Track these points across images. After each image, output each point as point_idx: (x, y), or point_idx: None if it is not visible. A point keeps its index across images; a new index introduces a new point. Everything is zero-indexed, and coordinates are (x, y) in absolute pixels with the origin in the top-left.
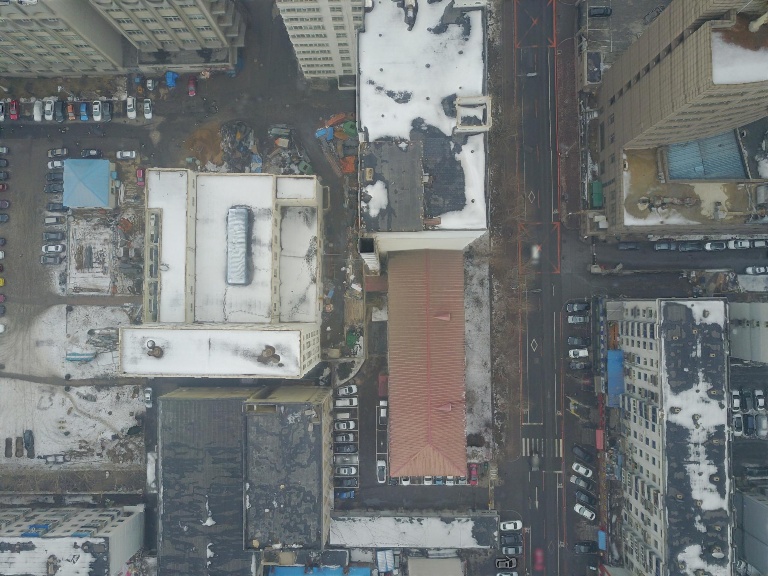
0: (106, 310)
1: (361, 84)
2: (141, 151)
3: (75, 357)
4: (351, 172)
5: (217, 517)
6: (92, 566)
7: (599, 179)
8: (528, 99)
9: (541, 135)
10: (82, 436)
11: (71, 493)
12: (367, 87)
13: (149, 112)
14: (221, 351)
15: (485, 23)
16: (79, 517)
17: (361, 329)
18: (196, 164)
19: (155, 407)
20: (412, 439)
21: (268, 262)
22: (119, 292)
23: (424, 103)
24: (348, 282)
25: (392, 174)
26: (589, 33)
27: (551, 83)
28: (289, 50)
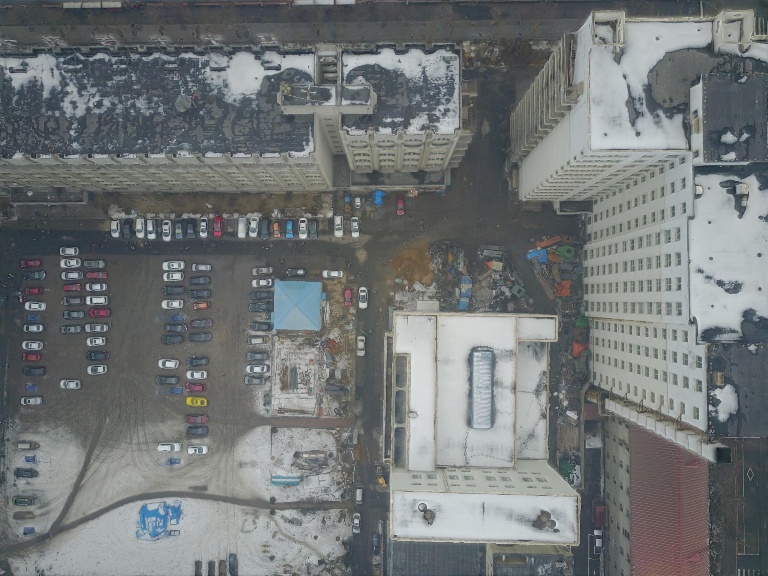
0: (312, 432)
1: (690, 273)
2: (347, 270)
3: (281, 480)
4: (565, 296)
5: None
6: None
7: None
8: None
9: None
10: (287, 560)
11: None
12: (696, 276)
13: (357, 231)
14: (495, 516)
15: None
16: None
17: (575, 457)
18: (404, 284)
19: (362, 532)
20: None
21: (510, 405)
22: (325, 414)
23: (756, 294)
24: (561, 408)
25: (742, 378)
26: None
27: None
28: (499, 169)
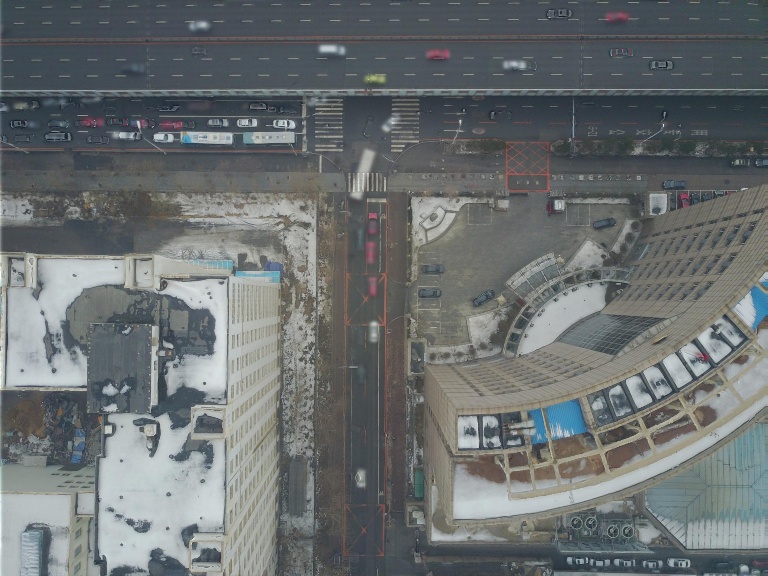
0: None
1: (100, 512)
2: None
3: None
4: None
5: None
6: None
7: (423, 465)
8: (357, 377)
9: (369, 414)
10: None
11: None
12: (106, 515)
13: None
14: None
15: (226, 455)
16: None
17: None
18: (18, 436)
19: None
20: None
21: None
22: None
23: (164, 533)
24: None
25: None
26: (419, 313)
27: (380, 362)
28: None
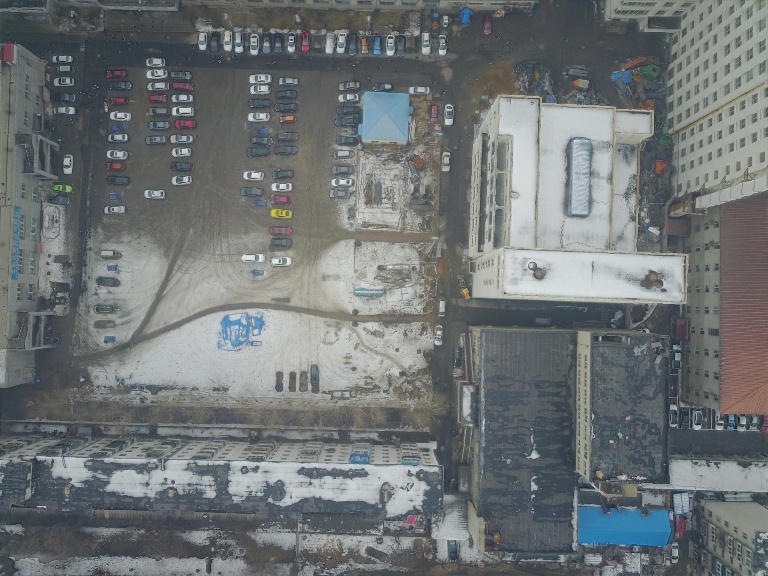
0: (395, 246)
1: None
2: (433, 88)
3: (364, 292)
4: None
5: (541, 450)
6: (426, 494)
7: None
8: None
9: None
10: (368, 372)
11: (356, 429)
12: None
13: (444, 48)
14: (604, 274)
15: None
16: (379, 451)
17: None
18: (489, 103)
19: (444, 345)
20: (750, 376)
21: (607, 195)
22: (409, 229)
23: None
24: (643, 225)
25: None
26: None
27: None
28: None
